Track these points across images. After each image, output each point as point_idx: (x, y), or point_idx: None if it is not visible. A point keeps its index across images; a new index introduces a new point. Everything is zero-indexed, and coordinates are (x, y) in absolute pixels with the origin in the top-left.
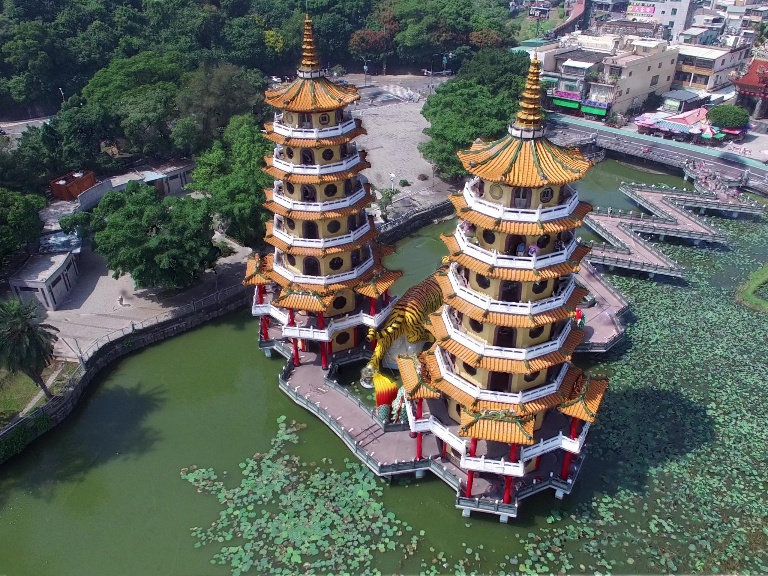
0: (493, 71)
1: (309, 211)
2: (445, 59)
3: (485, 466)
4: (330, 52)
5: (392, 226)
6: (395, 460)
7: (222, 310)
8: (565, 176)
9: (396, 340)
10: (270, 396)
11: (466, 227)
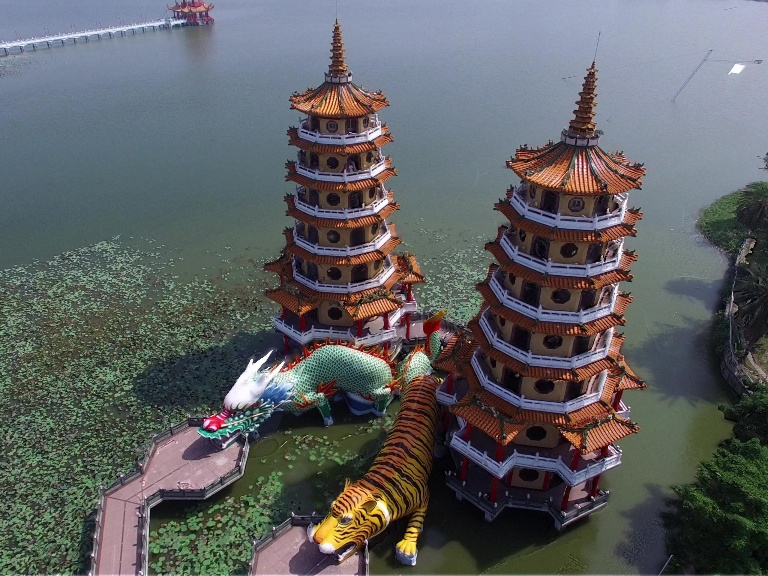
0: None
1: None
2: None
3: None
4: None
5: None
6: None
7: None
8: None
9: None
10: None
11: None
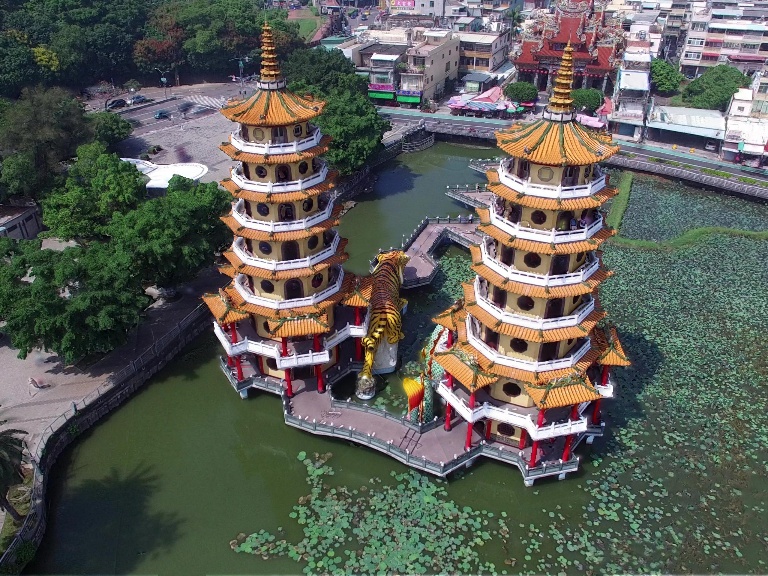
0: (317, 70)
1: (293, 230)
2: (241, 64)
3: (555, 432)
4: (112, 66)
5: None
6: None
7: (161, 363)
8: (608, 150)
9: (380, 345)
10: (245, 440)
11: (507, 213)
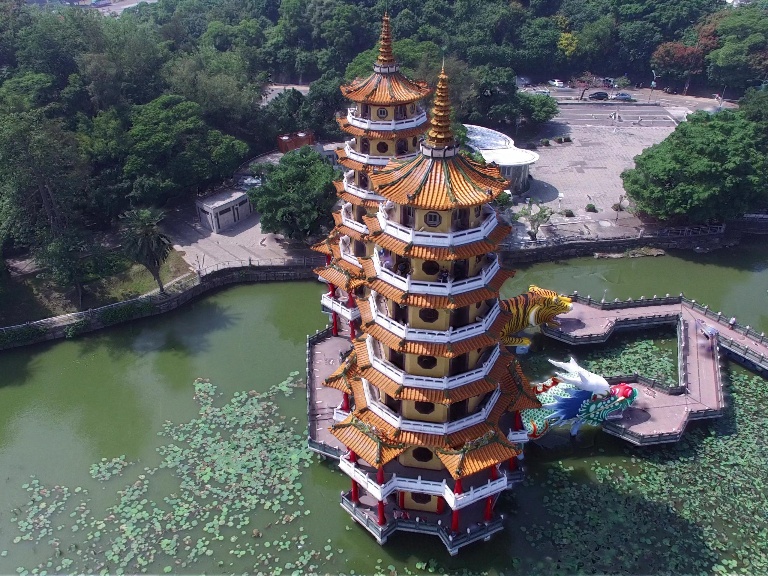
0: None
1: (357, 196)
2: None
3: (355, 474)
4: (629, 62)
5: (537, 246)
6: (323, 440)
7: None
8: (439, 202)
9: None
10: None
11: None
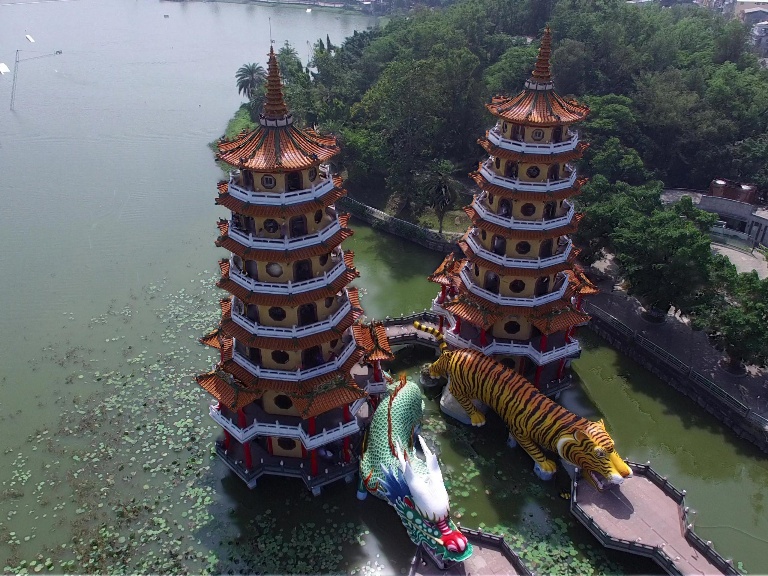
0: None
1: None
2: None
3: None
4: None
5: None
6: None
7: None
8: None
9: None
10: None
11: None
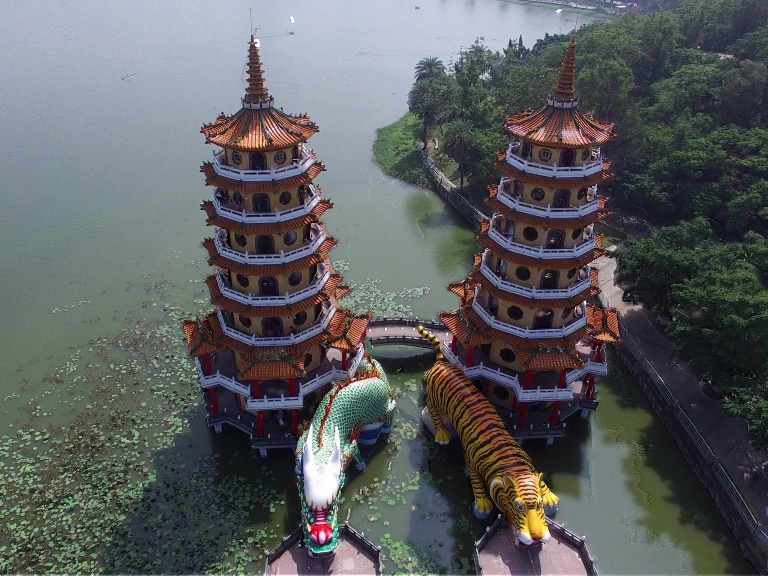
0: None
1: None
2: None
3: None
4: None
5: None
6: None
7: None
8: None
9: None
10: None
11: None
